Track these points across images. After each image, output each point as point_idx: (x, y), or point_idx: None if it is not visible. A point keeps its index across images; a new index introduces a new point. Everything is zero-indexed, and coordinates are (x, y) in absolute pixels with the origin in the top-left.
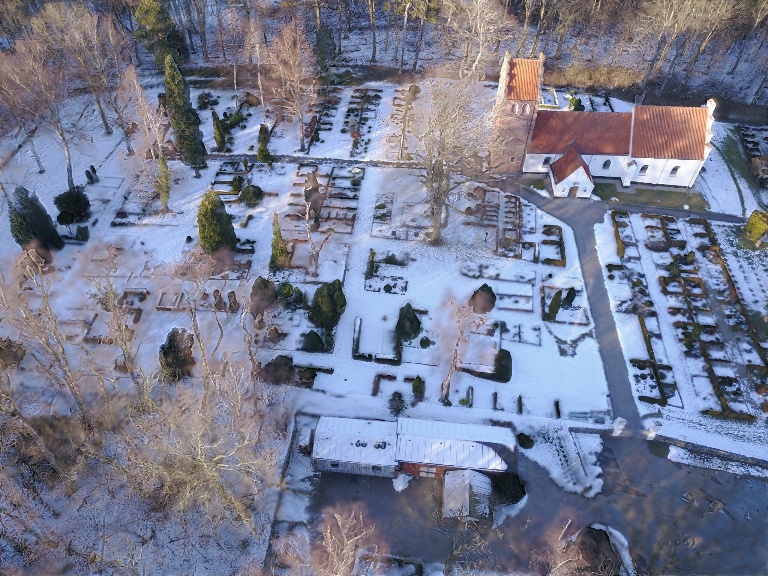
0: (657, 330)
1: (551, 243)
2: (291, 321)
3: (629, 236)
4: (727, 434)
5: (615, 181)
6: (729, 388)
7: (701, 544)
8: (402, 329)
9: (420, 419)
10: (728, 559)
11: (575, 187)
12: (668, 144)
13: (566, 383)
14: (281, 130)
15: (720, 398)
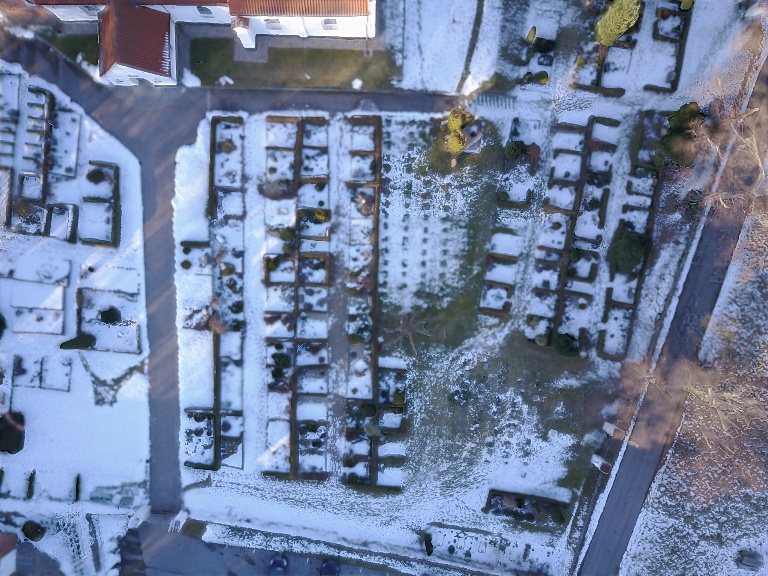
0: (237, 354)
1: (97, 201)
2: None
3: (232, 173)
4: (286, 500)
5: (234, 31)
6: (312, 435)
7: None
8: None
9: None
10: None
11: None
12: None
13: (97, 446)
14: None
15: (290, 456)
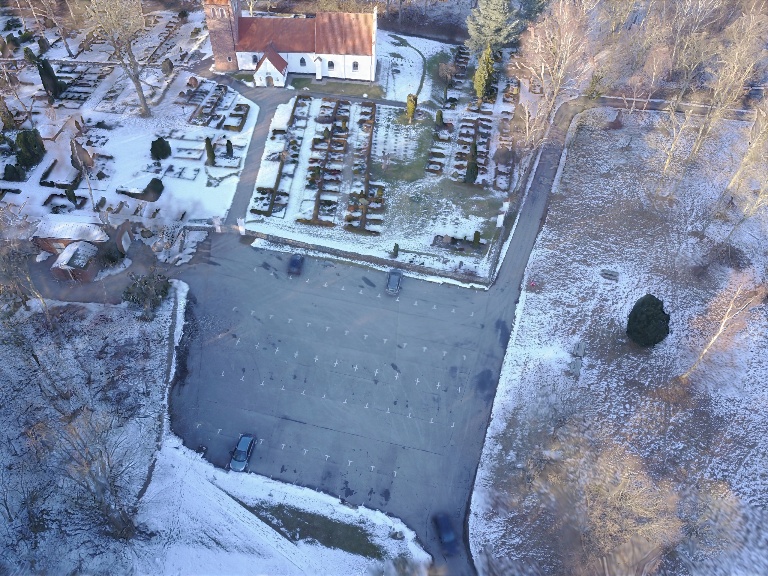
0: (291, 172)
1: (236, 116)
2: (3, 162)
3: (303, 112)
4: (307, 233)
5: (313, 76)
6: (327, 208)
7: (244, 291)
8: (72, 160)
9: (63, 214)
10: (259, 299)
11: (270, 77)
12: (343, 43)
13: (200, 202)
14: (62, 44)
15: (313, 212)
